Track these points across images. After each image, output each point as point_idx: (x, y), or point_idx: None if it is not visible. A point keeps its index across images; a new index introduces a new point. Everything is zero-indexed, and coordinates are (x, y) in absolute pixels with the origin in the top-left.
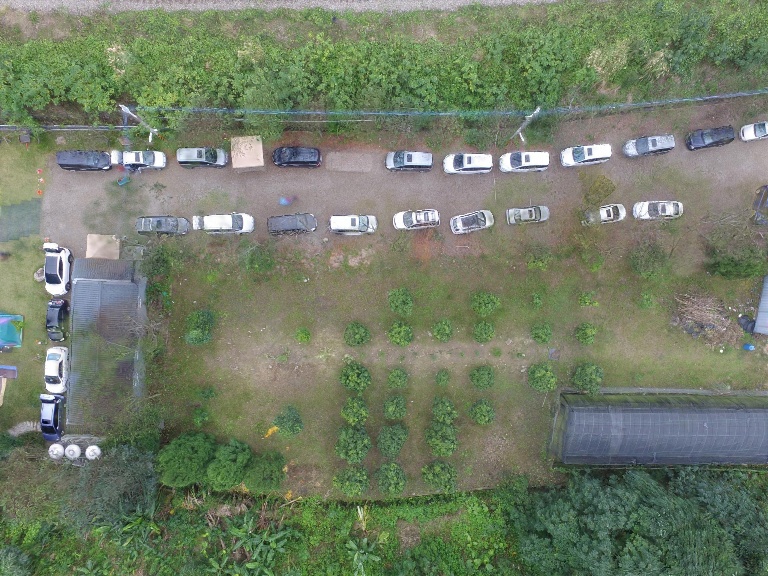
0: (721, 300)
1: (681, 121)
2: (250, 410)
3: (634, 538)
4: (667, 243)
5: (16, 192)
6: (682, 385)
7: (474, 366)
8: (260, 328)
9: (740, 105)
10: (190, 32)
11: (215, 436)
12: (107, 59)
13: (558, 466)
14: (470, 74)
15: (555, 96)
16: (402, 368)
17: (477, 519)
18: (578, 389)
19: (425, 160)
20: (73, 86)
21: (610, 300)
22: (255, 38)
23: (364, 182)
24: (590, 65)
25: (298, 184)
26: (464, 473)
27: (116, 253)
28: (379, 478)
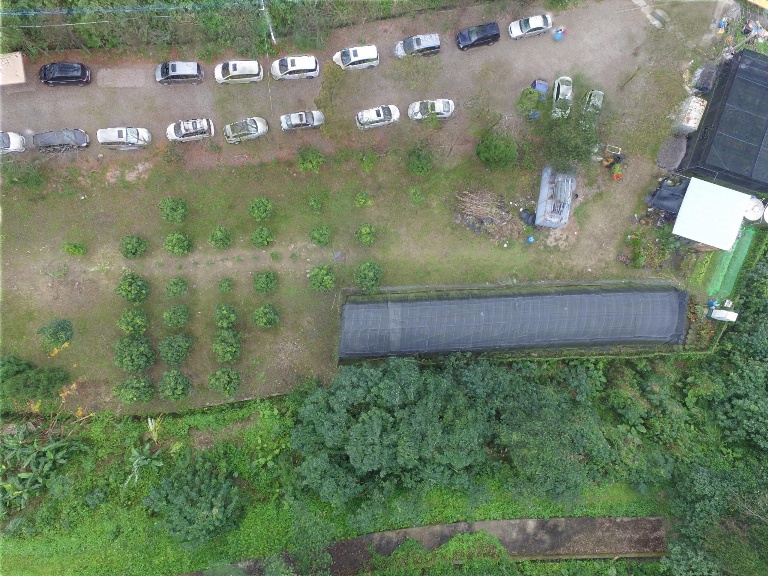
0: (502, 195)
1: (451, 22)
2: (34, 330)
3: (370, 409)
4: (445, 143)
5: None
6: (469, 281)
7: None
8: (39, 247)
9: (509, 4)
10: None
11: None
12: None
13: (343, 364)
14: None
15: None
16: (186, 279)
17: (267, 422)
18: (359, 288)
19: (190, 69)
20: None
21: (392, 201)
22: None
23: (137, 97)
24: None
25: (70, 102)
26: (257, 380)
27: None
28: (160, 385)
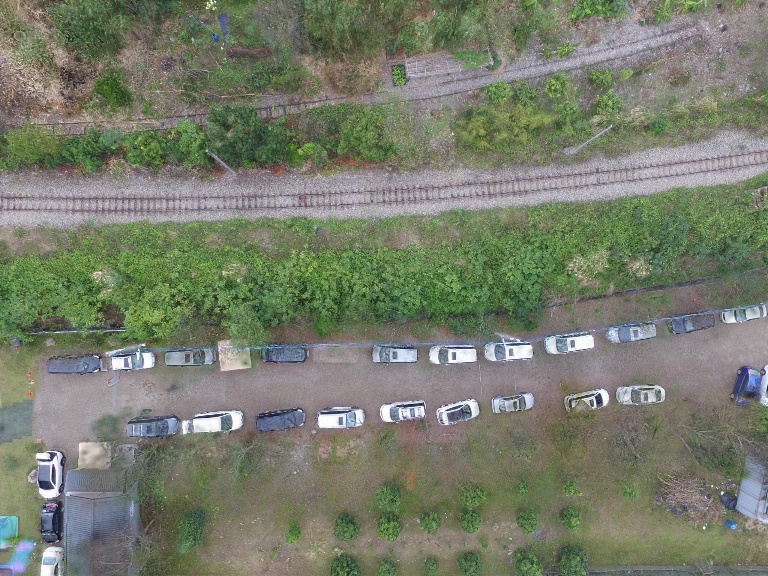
0: (703, 478)
1: (663, 304)
2: None
3: None
4: (650, 424)
5: (7, 395)
6: (666, 562)
7: (462, 551)
8: (251, 520)
9: (721, 286)
10: (175, 243)
11: None
12: None
13: None
14: (453, 283)
15: (538, 294)
16: (391, 555)
17: None
18: (564, 575)
19: (410, 357)
20: None
21: (595, 481)
22: (240, 250)
23: (351, 373)
24: (571, 271)
25: (286, 377)
26: None
27: (108, 461)
28: None
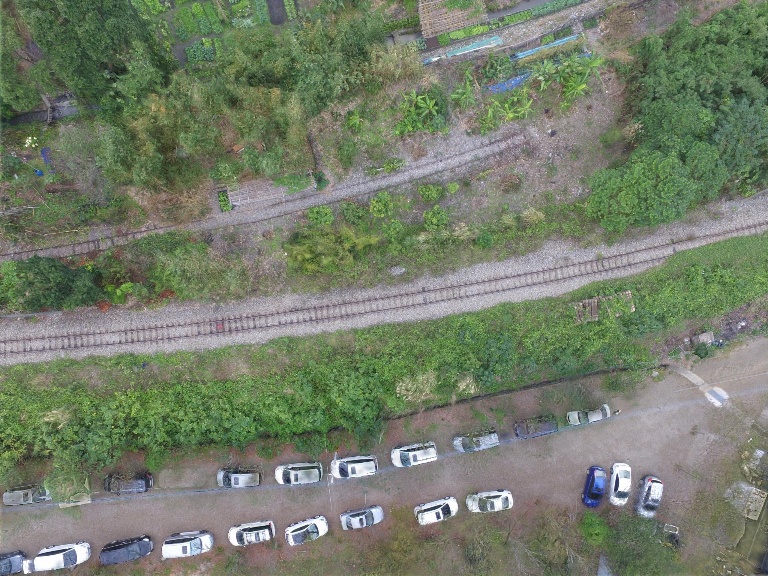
0: None
1: (509, 409)
2: None
3: None
4: (503, 528)
5: None
6: None
7: None
8: None
9: (566, 387)
10: (3, 386)
11: None
12: None
13: None
14: (281, 413)
15: (374, 413)
16: None
17: None
18: None
19: (252, 481)
20: None
21: None
22: (66, 392)
23: (199, 497)
24: (399, 394)
25: (133, 505)
26: None
27: None
28: None
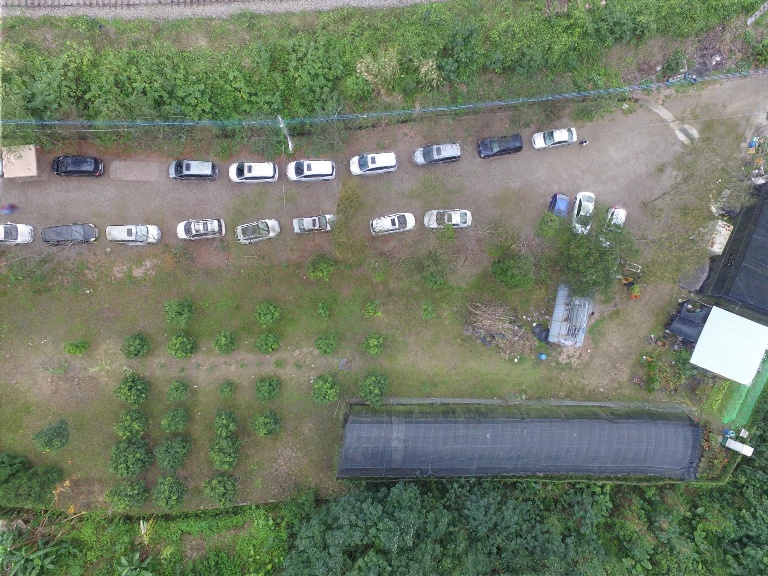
0: (515, 309)
1: (474, 129)
2: (30, 424)
3: (367, 554)
4: (460, 252)
5: None
6: (476, 395)
7: (261, 377)
8: (41, 340)
9: (534, 113)
10: None
11: None
12: None
13: (342, 478)
14: (237, 82)
15: (334, 104)
16: (187, 380)
17: (261, 532)
18: (363, 400)
19: (204, 169)
20: None
21: (402, 309)
22: (18, 46)
23: (149, 191)
24: (360, 73)
25: (81, 193)
26: (254, 486)
27: None
28: (154, 492)
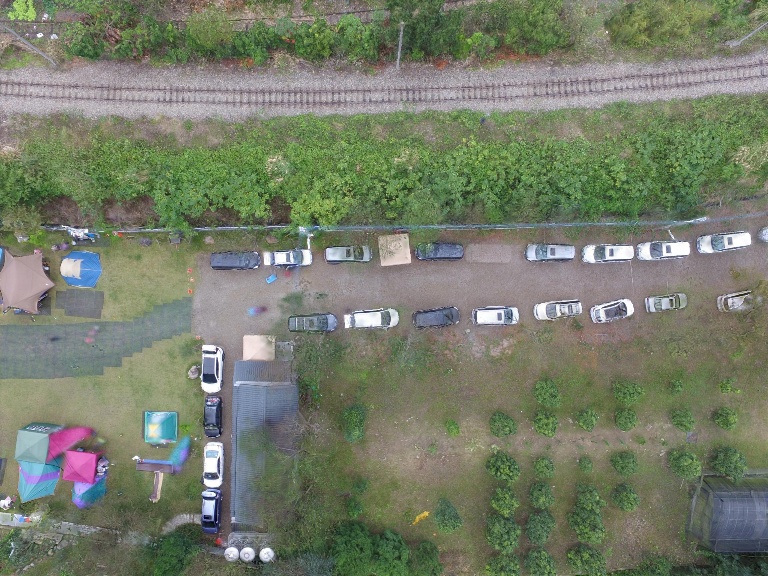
0: None
1: None
2: (398, 498)
3: None
4: None
5: (167, 292)
6: None
7: (615, 451)
8: (406, 418)
9: None
10: (340, 136)
11: (365, 525)
12: (262, 166)
13: (701, 549)
14: (620, 173)
15: (698, 188)
16: (545, 455)
17: None
18: (720, 474)
19: (568, 253)
20: (231, 194)
21: (746, 383)
22: (406, 142)
23: (504, 273)
24: (738, 161)
25: (439, 276)
26: (605, 554)
27: (272, 353)
28: (530, 566)
